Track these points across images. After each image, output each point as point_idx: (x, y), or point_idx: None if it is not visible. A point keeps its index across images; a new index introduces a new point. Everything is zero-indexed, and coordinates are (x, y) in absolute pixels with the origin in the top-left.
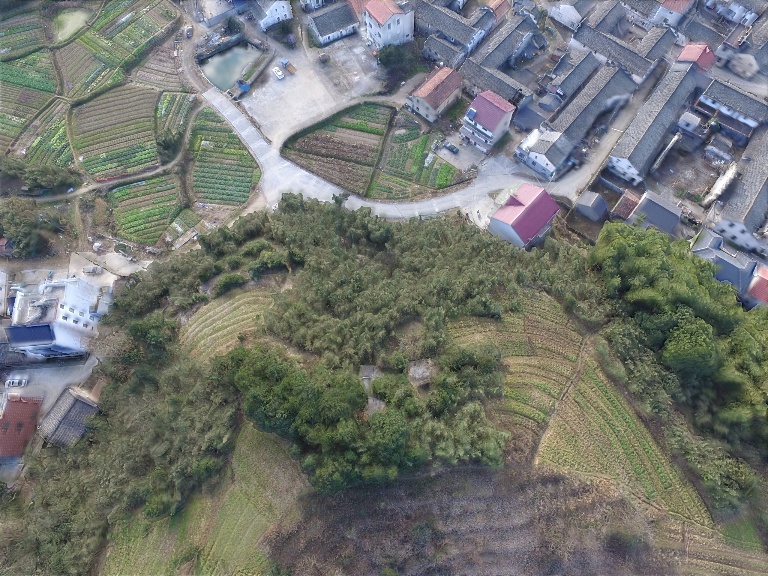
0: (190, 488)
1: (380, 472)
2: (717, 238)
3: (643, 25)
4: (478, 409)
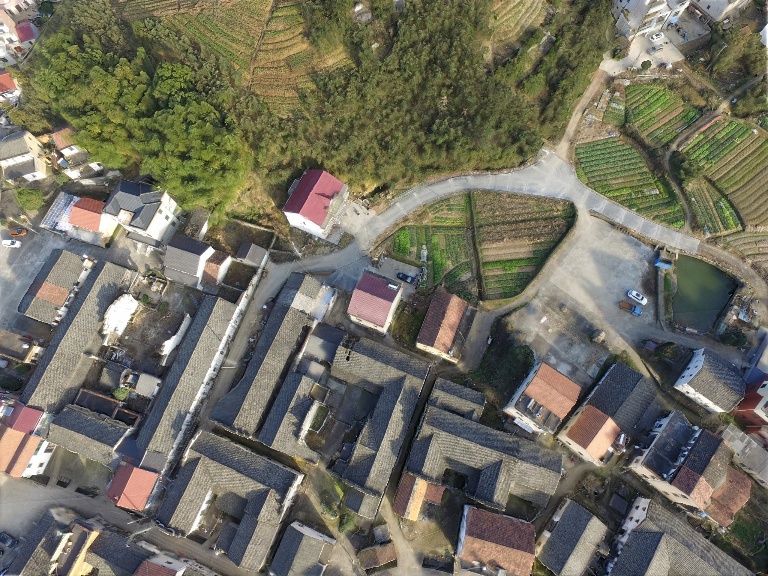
0: None
1: None
2: (136, 218)
3: (201, 567)
4: None
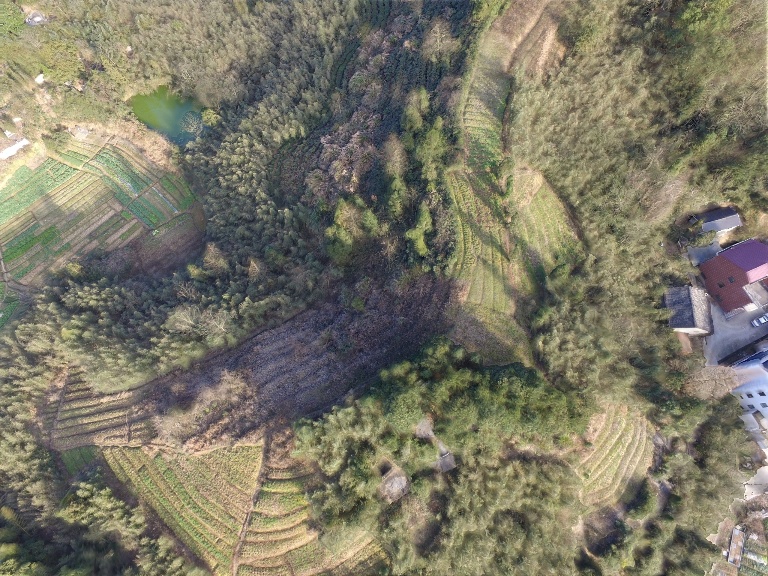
0: (546, 300)
1: (395, 370)
2: None
3: None
4: (326, 465)
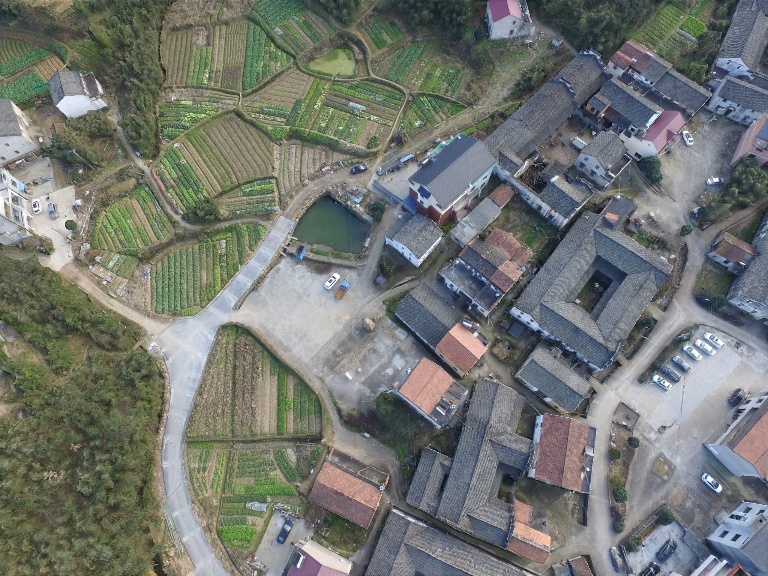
0: None
1: None
2: None
3: None
4: None
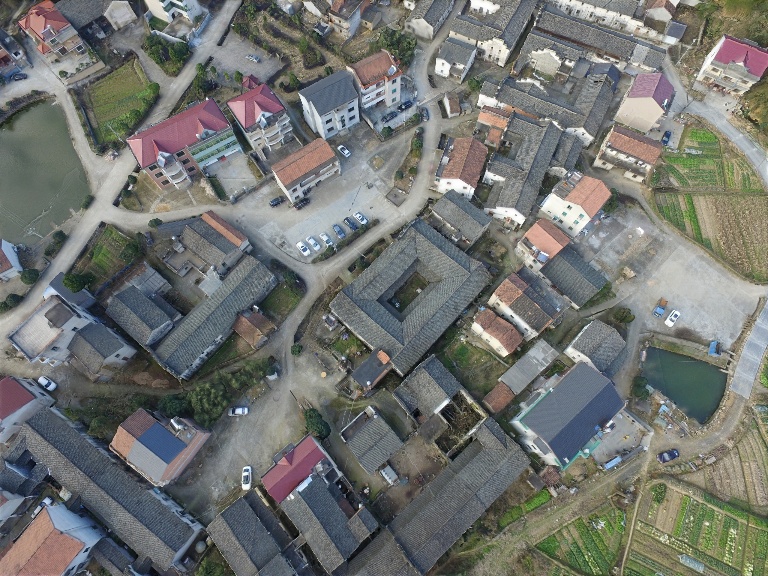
0: None
1: None
2: None
3: None
4: None
